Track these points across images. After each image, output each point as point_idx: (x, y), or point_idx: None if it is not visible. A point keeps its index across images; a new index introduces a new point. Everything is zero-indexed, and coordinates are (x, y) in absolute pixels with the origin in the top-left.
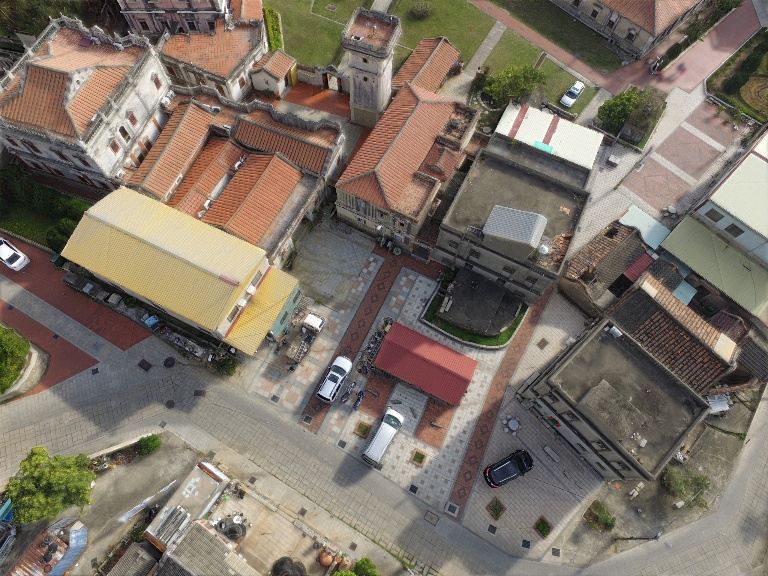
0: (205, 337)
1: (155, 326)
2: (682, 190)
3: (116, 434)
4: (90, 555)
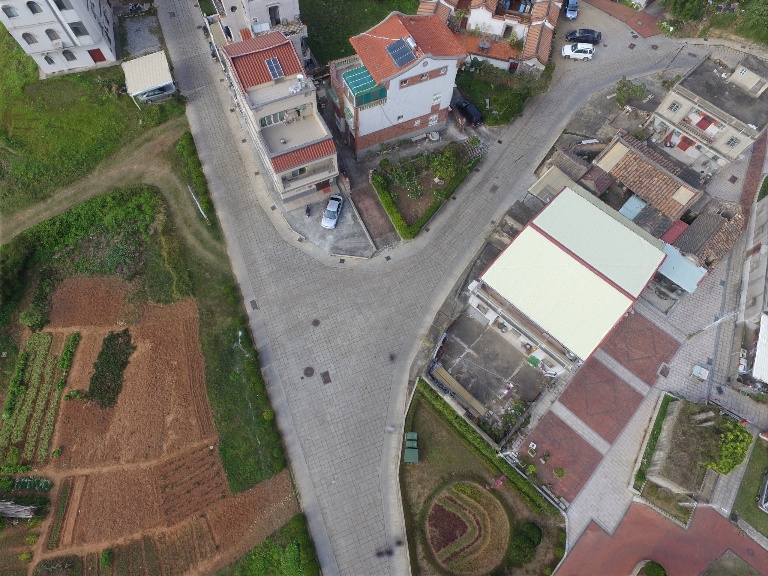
0: None
1: None
2: (611, 340)
3: None
4: None
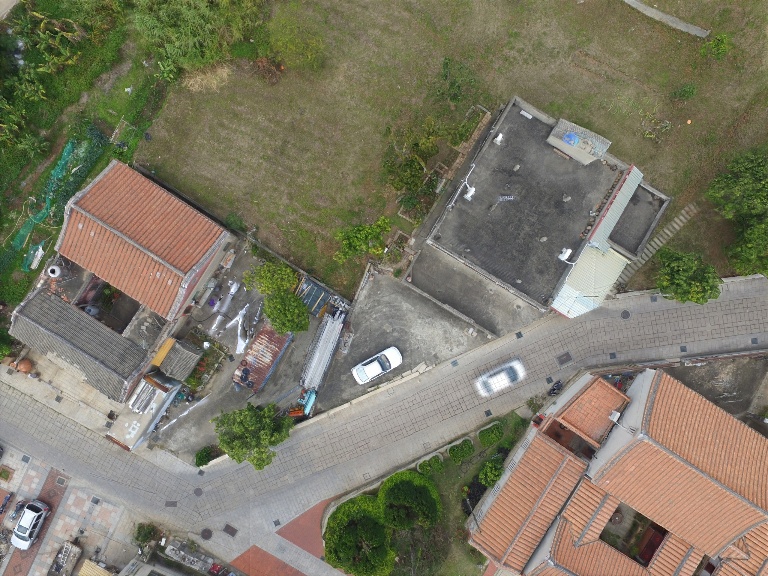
0: (174, 563)
1: (223, 575)
2: None
3: (242, 463)
4: (237, 364)
